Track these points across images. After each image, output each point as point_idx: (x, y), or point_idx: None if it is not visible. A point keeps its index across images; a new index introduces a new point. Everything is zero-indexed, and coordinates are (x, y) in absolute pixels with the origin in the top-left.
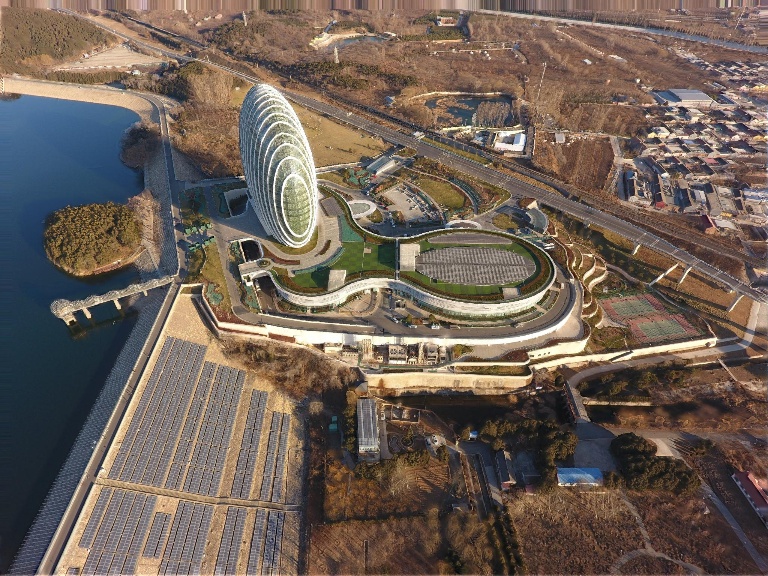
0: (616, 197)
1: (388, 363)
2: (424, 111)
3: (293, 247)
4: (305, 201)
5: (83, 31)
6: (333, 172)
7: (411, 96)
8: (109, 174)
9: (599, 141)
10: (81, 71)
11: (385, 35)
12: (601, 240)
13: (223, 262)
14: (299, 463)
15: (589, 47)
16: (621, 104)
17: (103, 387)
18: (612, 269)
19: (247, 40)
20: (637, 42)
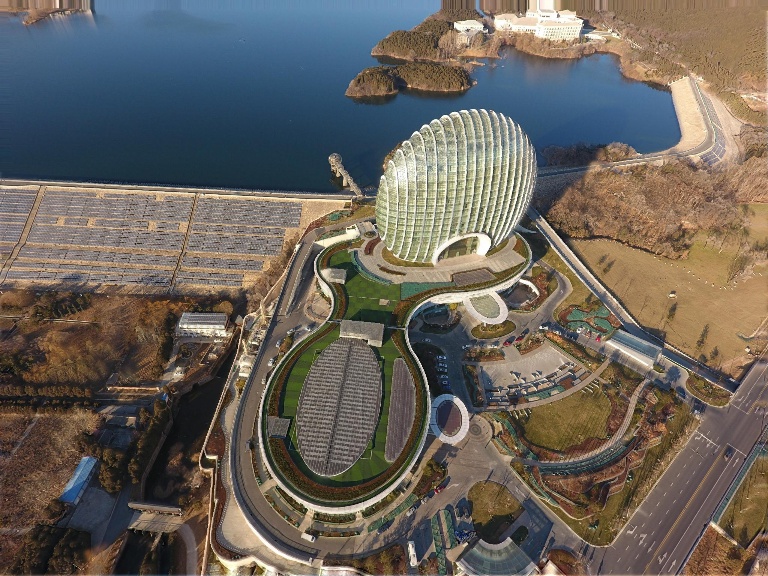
0: None
1: None
2: None
3: None
4: (382, 208)
5: None
6: (592, 295)
7: None
8: None
9: None
10: (763, 106)
11: None
12: None
13: None
14: (200, 292)
15: None
16: None
17: (271, 190)
18: None
19: None
20: None
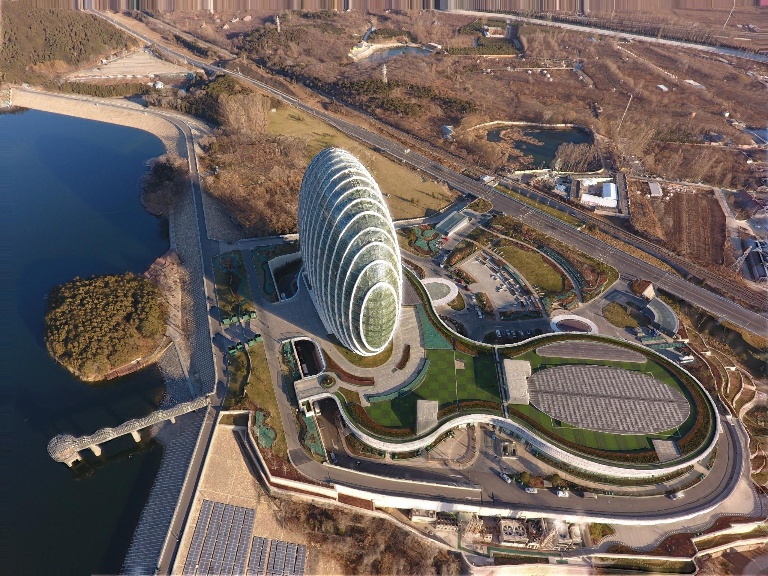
0: (741, 276)
1: (499, 544)
2: (492, 148)
3: (363, 356)
4: (391, 313)
5: (102, 33)
6: None
7: (471, 126)
8: (127, 224)
9: (702, 195)
10: (98, 81)
11: (430, 46)
12: (740, 343)
13: (273, 375)
14: None
15: (659, 69)
16: (714, 144)
17: None
18: (761, 388)
19: (281, 49)
20: (711, 64)
